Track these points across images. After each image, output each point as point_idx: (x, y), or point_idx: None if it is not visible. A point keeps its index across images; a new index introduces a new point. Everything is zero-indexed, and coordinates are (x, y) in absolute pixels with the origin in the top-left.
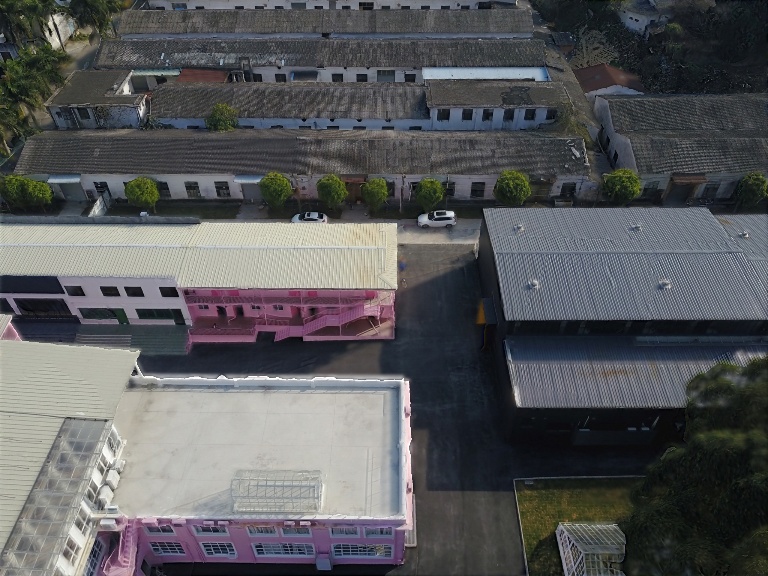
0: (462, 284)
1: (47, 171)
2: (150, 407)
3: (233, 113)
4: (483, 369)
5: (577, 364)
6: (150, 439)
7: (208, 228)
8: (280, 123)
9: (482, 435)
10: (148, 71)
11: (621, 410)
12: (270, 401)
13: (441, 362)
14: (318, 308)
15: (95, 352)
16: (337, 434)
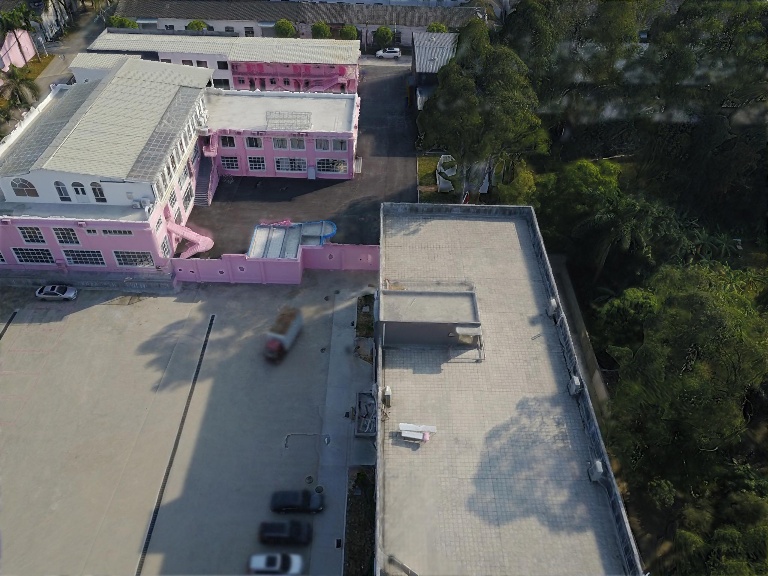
0: (400, 82)
1: (136, 16)
2: (219, 101)
3: None
4: (407, 114)
5: None
6: (221, 110)
7: (244, 38)
8: None
9: (402, 138)
10: None
11: None
12: (284, 101)
13: (383, 111)
14: (311, 81)
15: (191, 67)
16: (320, 112)
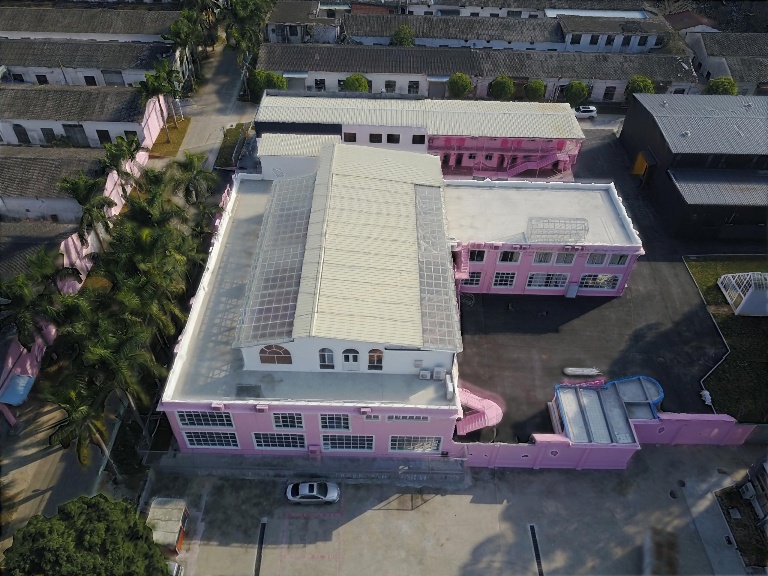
0: (612, 152)
1: (282, 69)
2: None
3: (413, 33)
4: (644, 199)
5: (721, 184)
6: (453, 210)
7: (432, 102)
8: (447, 43)
9: (654, 233)
10: (323, 6)
11: (758, 206)
12: (524, 194)
13: None
14: (521, 157)
15: (412, 154)
16: (577, 210)
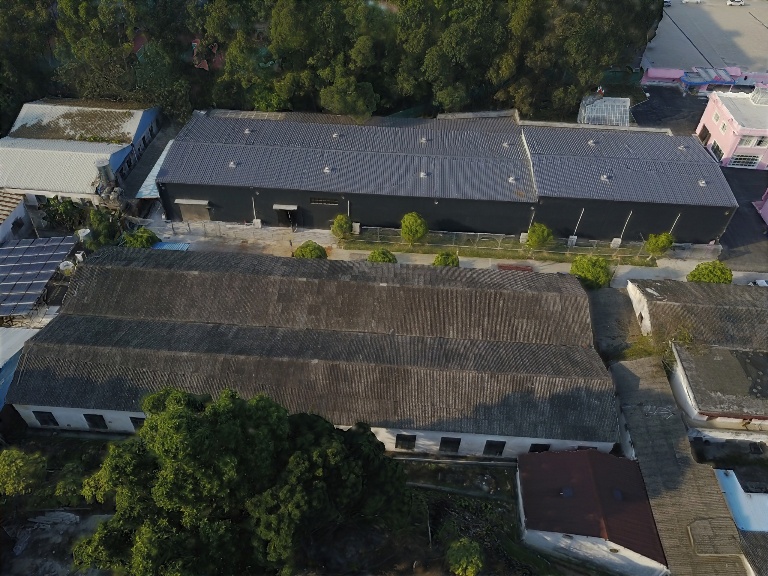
0: None
1: None
2: None
3: None
4: None
5: None
6: None
7: None
8: None
9: None
10: None
11: None
12: None
13: None
14: None
15: None
16: (761, 118)
